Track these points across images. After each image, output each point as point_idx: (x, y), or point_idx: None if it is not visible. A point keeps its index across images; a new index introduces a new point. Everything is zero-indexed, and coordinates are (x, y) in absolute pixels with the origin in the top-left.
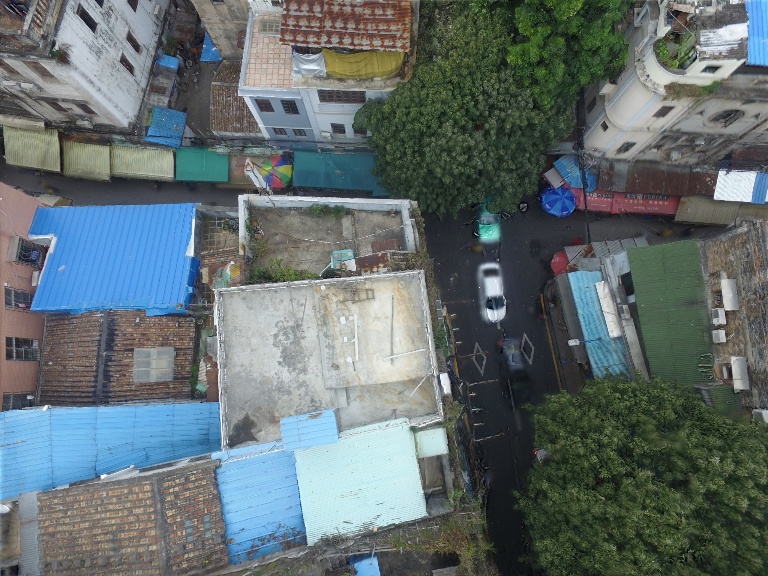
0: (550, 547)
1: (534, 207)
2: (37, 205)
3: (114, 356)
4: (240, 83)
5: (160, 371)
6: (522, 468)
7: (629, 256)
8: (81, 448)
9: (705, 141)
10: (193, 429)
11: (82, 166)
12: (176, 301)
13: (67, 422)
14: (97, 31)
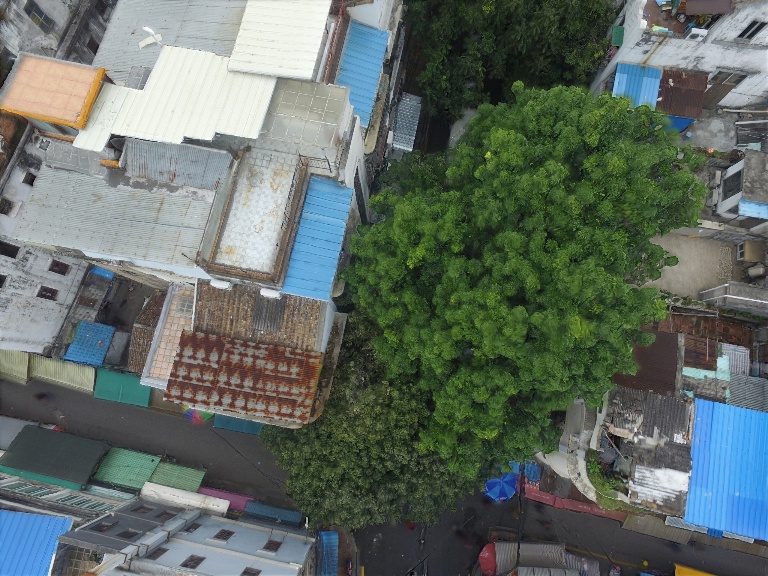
0: None
1: None
2: None
3: None
4: (143, 373)
5: None
6: None
7: None
8: None
9: None
10: None
11: None
12: None
13: None
14: (5, 284)
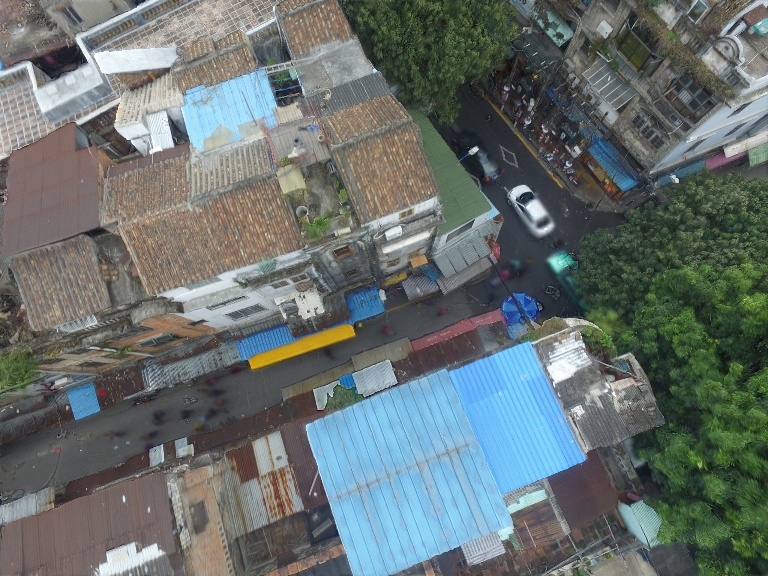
0: None
1: None
2: None
3: None
4: None
5: None
6: None
7: None
8: None
9: None
10: None
11: None
12: None
13: None
14: None
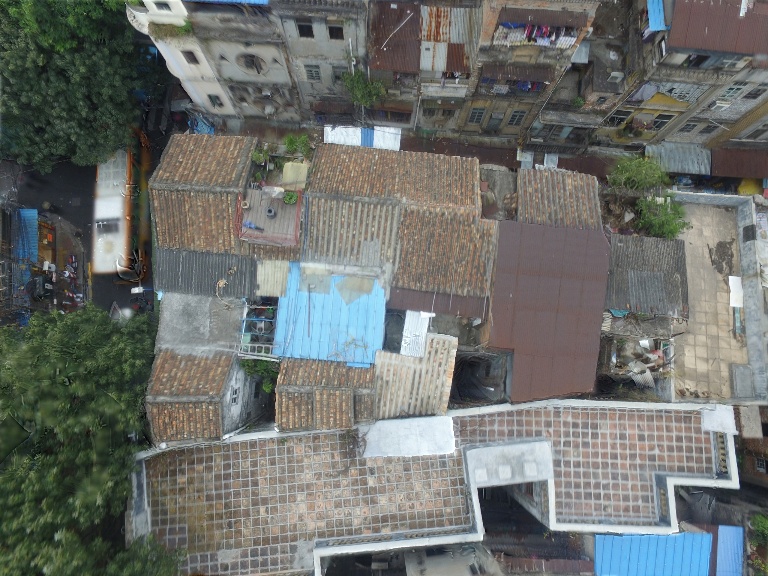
0: None
1: None
2: None
3: None
4: None
5: None
6: None
7: None
8: None
9: (270, 92)
10: None
11: None
12: None
13: None
14: None
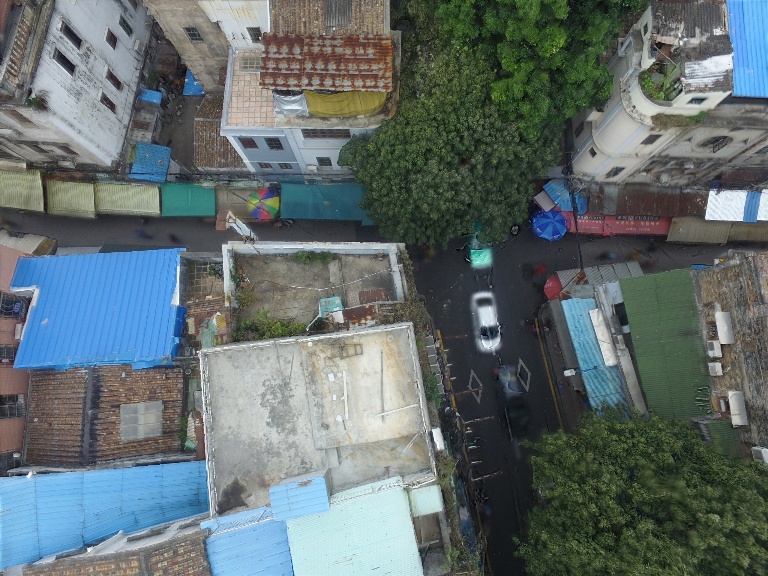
0: None
1: (525, 230)
2: (18, 256)
3: (100, 413)
4: (222, 123)
5: (148, 426)
6: (522, 500)
7: (622, 287)
8: (68, 515)
9: (694, 165)
10: (183, 489)
11: (66, 204)
12: (162, 353)
13: (52, 488)
14: (75, 73)
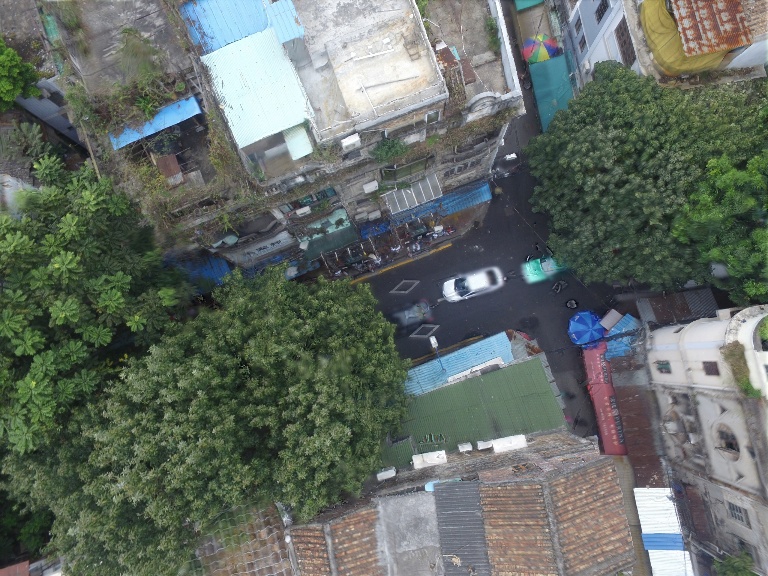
0: (236, 277)
1: None
2: None
3: None
4: None
5: None
6: None
7: (531, 360)
8: None
9: (696, 443)
10: None
11: None
12: None
13: None
14: None
